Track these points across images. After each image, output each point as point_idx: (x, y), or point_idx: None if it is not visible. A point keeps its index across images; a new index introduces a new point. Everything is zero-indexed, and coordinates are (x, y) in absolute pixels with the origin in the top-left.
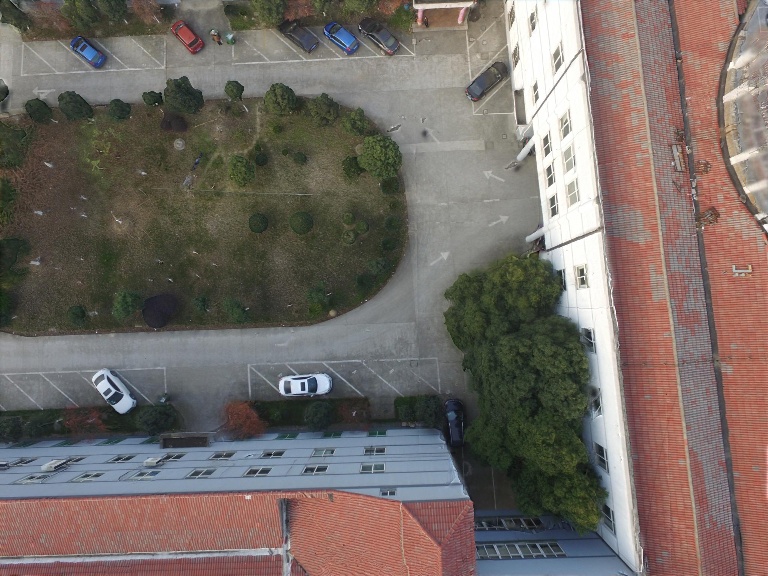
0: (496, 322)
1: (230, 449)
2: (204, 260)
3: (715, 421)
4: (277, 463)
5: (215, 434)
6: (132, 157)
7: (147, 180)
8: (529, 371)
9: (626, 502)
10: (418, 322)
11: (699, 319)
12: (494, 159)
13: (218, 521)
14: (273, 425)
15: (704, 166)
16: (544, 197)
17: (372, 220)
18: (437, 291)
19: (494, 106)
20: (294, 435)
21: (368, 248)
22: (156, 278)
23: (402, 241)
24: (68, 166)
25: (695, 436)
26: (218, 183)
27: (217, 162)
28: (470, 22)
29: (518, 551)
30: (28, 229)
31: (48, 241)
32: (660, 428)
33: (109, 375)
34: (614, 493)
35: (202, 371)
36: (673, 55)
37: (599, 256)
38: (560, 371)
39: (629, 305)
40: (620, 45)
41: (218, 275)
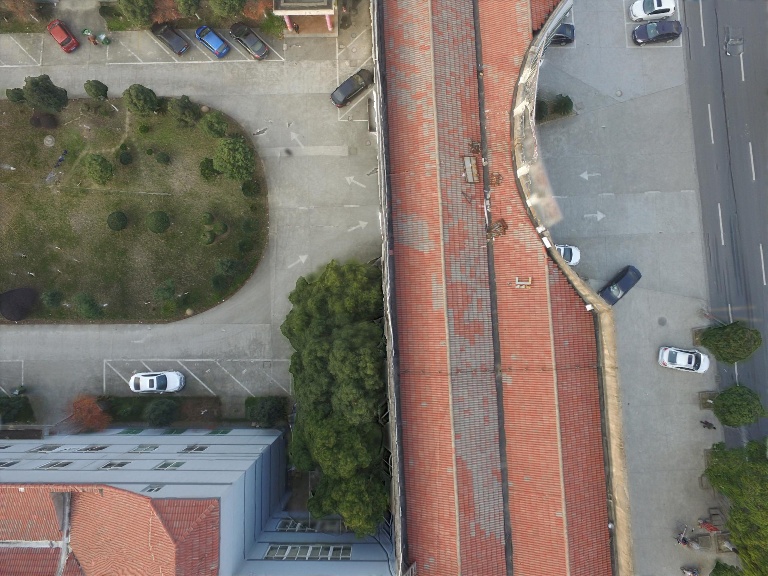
0: (312, 326)
1: (59, 442)
2: (66, 256)
3: (492, 431)
4: (83, 457)
5: (52, 427)
6: (2, 152)
7: (15, 175)
8: (325, 375)
9: None
10: (273, 324)
11: (481, 329)
12: (357, 165)
13: None
14: (119, 421)
15: (496, 178)
16: None
17: (233, 221)
18: None
19: (359, 113)
20: (140, 431)
21: (227, 249)
22: (19, 272)
23: (262, 243)
24: None
25: (465, 445)
26: (84, 180)
27: None
28: (341, 29)
29: (307, 553)
30: None
31: None
32: (433, 436)
33: None
34: (390, 498)
35: (59, 365)
36: (474, 68)
37: None
38: (345, 376)
39: (413, 313)
40: (417, 57)
41: (79, 271)
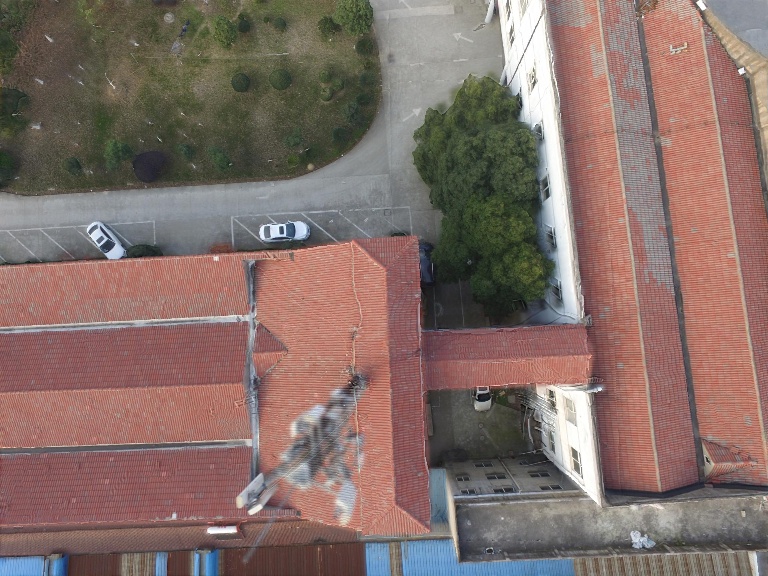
0: (455, 134)
1: None
2: (191, 121)
3: (655, 190)
4: None
5: None
6: (126, 31)
7: (139, 50)
8: None
9: (569, 259)
10: (391, 174)
11: (639, 96)
12: (463, 22)
13: (189, 285)
14: None
15: None
16: (505, 34)
17: (348, 80)
18: (409, 145)
19: None
20: None
21: (344, 106)
22: (147, 139)
23: (376, 100)
24: (67, 40)
25: (634, 198)
26: (204, 51)
27: (204, 32)
28: None
29: None
30: (30, 98)
31: (48, 108)
32: (601, 193)
33: (102, 226)
34: (560, 260)
35: (189, 223)
36: None
37: (542, 39)
38: (508, 150)
39: (572, 85)
40: None
41: (204, 134)
